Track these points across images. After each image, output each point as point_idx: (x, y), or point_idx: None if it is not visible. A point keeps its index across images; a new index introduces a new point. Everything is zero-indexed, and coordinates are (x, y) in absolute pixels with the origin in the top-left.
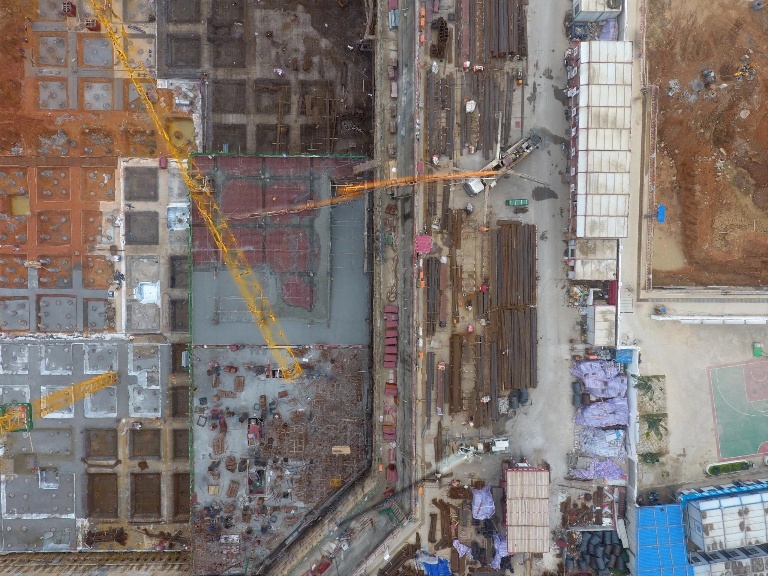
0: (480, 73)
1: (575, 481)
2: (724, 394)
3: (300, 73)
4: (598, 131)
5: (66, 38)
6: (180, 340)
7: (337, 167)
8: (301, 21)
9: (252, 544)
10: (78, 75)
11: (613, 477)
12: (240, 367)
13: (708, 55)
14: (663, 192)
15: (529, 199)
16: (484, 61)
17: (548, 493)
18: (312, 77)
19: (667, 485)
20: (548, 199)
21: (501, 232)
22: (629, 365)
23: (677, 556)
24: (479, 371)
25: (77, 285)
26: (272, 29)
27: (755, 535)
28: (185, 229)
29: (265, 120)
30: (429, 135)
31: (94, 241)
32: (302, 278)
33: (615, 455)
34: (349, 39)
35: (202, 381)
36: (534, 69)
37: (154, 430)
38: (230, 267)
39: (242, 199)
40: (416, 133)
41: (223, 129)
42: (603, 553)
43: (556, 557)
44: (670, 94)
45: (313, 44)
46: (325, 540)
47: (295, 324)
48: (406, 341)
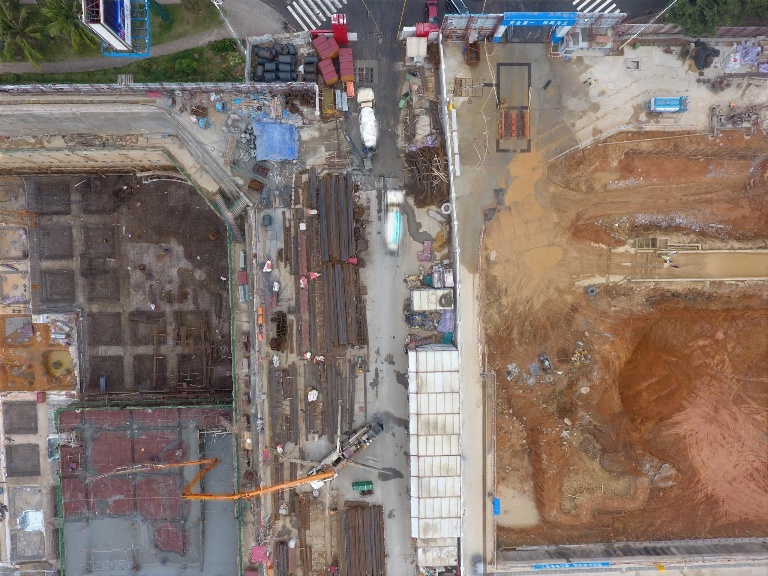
0: (321, 363)
1: None
2: None
3: (175, 304)
4: (428, 438)
5: None
6: None
7: (204, 416)
8: (174, 253)
9: None
10: None
11: None
12: None
13: (545, 339)
14: (514, 455)
15: (375, 480)
16: (325, 351)
17: None
18: (187, 307)
19: None
20: (394, 479)
21: (348, 514)
22: None
23: None
24: None
25: None
26: (145, 262)
27: None
28: None
29: (142, 351)
30: (272, 426)
31: None
32: (174, 524)
33: None
34: (222, 270)
35: None
36: (375, 356)
37: None
38: (102, 516)
39: (111, 450)
40: (257, 428)
41: (99, 362)
42: None
43: None
44: (508, 379)
45: (187, 275)
46: None
47: (168, 569)
48: None
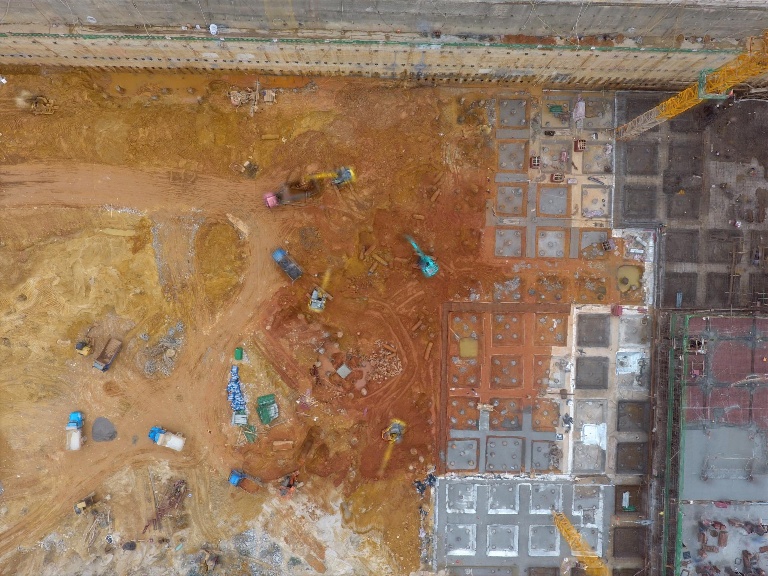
0: None
1: None
2: None
3: (752, 223)
4: None
5: (526, 188)
6: (625, 482)
7: None
8: (755, 173)
9: None
10: (537, 224)
11: None
12: (723, 522)
13: None
14: None
15: None
16: None
17: None
18: (763, 227)
19: None
20: None
21: None
22: None
23: None
24: None
25: (527, 427)
26: (726, 181)
27: None
28: (630, 373)
29: (715, 269)
30: None
31: (541, 384)
32: None
33: None
34: None
35: (686, 535)
36: None
37: (592, 568)
38: (718, 425)
39: (732, 359)
40: None
41: (677, 278)
42: None
43: None
44: None
45: (766, 196)
46: None
47: None
48: None
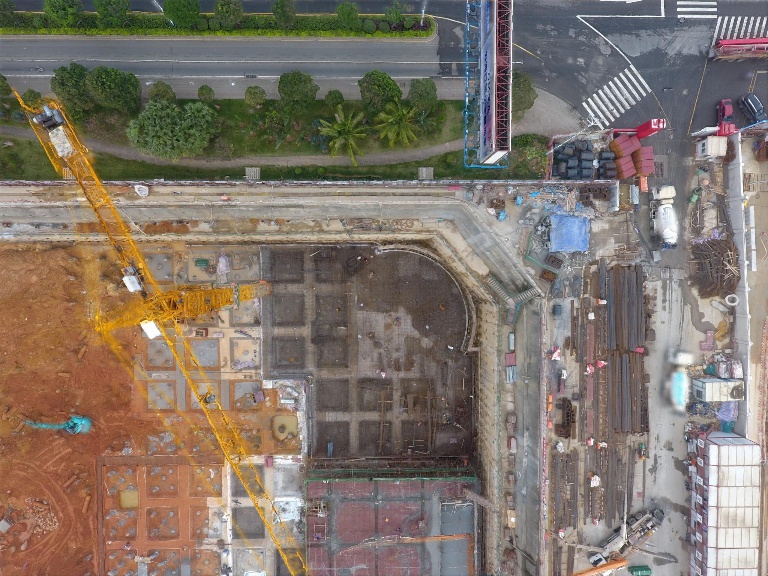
0: (603, 449)
1: None
2: None
3: (401, 371)
4: (727, 531)
5: None
6: None
7: (447, 487)
8: (402, 322)
9: None
10: None
11: None
12: None
13: None
14: None
15: (650, 565)
16: (607, 437)
17: None
18: (413, 375)
19: None
20: (669, 564)
21: None
22: None
23: None
24: None
25: None
26: (374, 330)
27: None
28: (289, 520)
29: (367, 417)
30: (555, 511)
31: (201, 533)
32: None
33: None
34: (449, 340)
35: None
36: (655, 442)
37: None
38: None
39: (355, 520)
40: (544, 514)
41: (327, 428)
42: None
43: None
44: None
45: (414, 344)
46: None
47: None
48: None
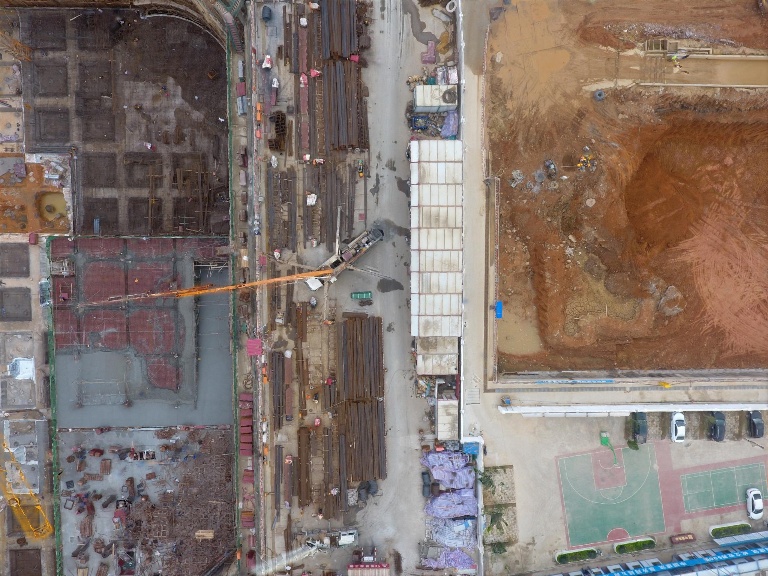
0: (321, 166)
1: (427, 570)
2: (572, 483)
3: (171, 146)
4: (429, 231)
5: None
6: None
7: (200, 247)
8: (171, 93)
9: None
10: None
11: (463, 566)
12: (107, 450)
13: (551, 145)
14: (517, 277)
15: (374, 291)
16: (325, 154)
17: None
18: (184, 150)
19: (517, 574)
20: (394, 291)
21: (346, 325)
22: (478, 455)
23: None
24: (327, 464)
25: None
26: (142, 101)
27: None
28: None
29: (137, 194)
30: (269, 230)
31: None
32: (167, 359)
33: (463, 546)
34: (220, 111)
35: (68, 464)
36: (376, 161)
37: None
38: (93, 350)
39: (104, 281)
40: (254, 229)
41: (93, 204)
42: None
43: None
44: (512, 185)
45: (184, 116)
46: None
47: (161, 406)
48: (256, 433)
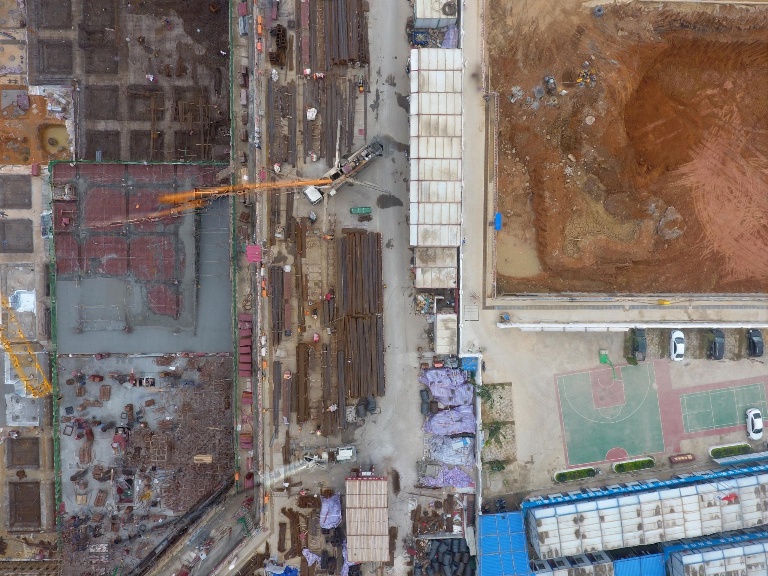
0: (321, 80)
1: (425, 489)
2: (571, 401)
3: (173, 79)
4: (429, 139)
5: None
6: (56, 348)
7: (201, 174)
8: (174, 26)
9: (121, 553)
10: None
11: (462, 485)
12: (106, 376)
13: (550, 61)
14: (516, 199)
15: (374, 207)
16: (325, 68)
17: (387, 502)
18: (186, 83)
19: (515, 492)
20: (393, 207)
21: (345, 240)
22: (476, 373)
23: (519, 564)
24: (326, 380)
25: None
26: (144, 35)
27: (591, 542)
28: None
29: (139, 126)
30: (269, 143)
31: None
32: (167, 286)
33: (462, 463)
34: (222, 44)
35: (68, 390)
36: (376, 76)
37: (33, 439)
38: (94, 275)
39: (105, 207)
40: (254, 141)
41: (96, 136)
42: (452, 561)
43: (407, 565)
44: (512, 101)
45: (186, 50)
46: (185, 549)
47: (161, 332)
48: (255, 350)
